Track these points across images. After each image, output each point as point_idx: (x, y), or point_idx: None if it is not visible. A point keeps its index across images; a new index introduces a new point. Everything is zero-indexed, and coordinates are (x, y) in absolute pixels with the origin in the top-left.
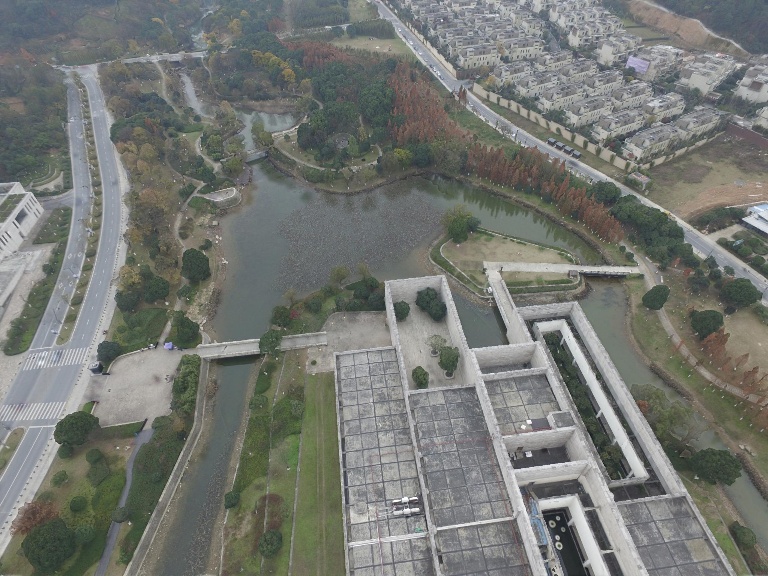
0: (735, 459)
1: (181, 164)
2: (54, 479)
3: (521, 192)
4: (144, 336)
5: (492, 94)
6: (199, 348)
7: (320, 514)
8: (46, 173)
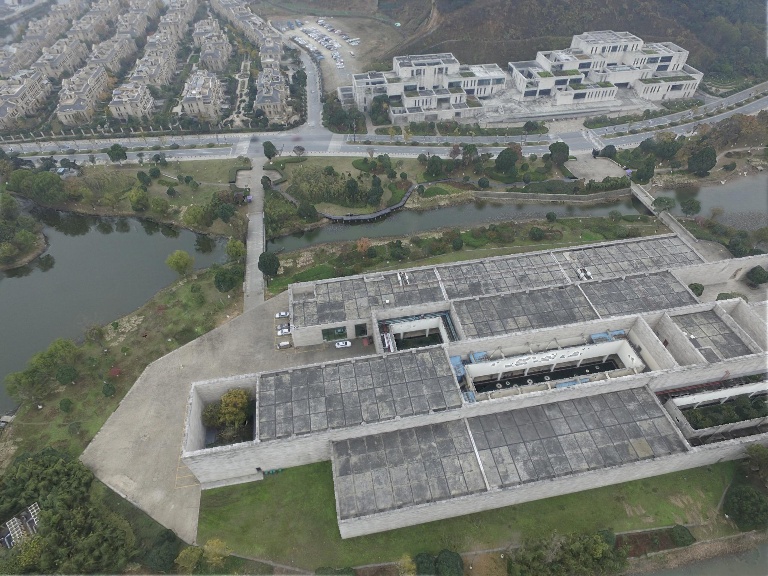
0: (765, 515)
1: None
2: (532, 154)
3: None
4: (629, 162)
5: None
6: (637, 186)
7: None
8: (726, 83)
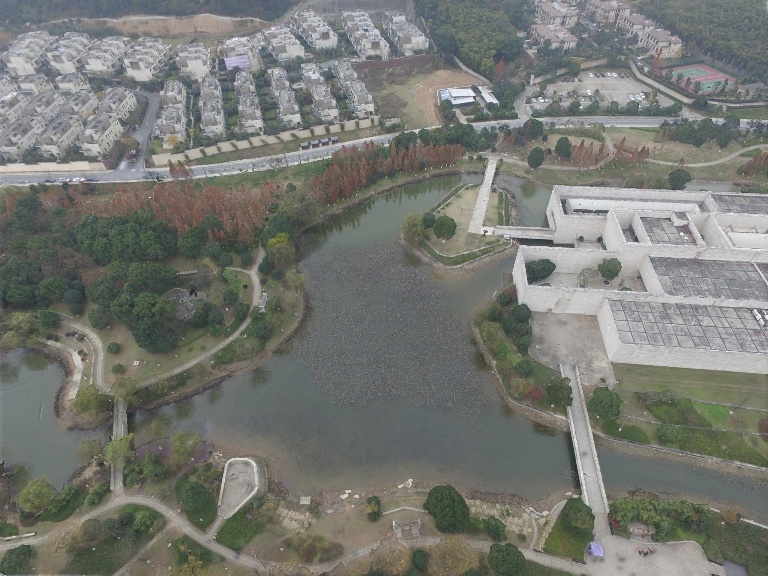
0: (680, 169)
1: (76, 574)
2: None
3: (371, 186)
4: None
5: (190, 152)
6: None
7: (765, 391)
8: None
